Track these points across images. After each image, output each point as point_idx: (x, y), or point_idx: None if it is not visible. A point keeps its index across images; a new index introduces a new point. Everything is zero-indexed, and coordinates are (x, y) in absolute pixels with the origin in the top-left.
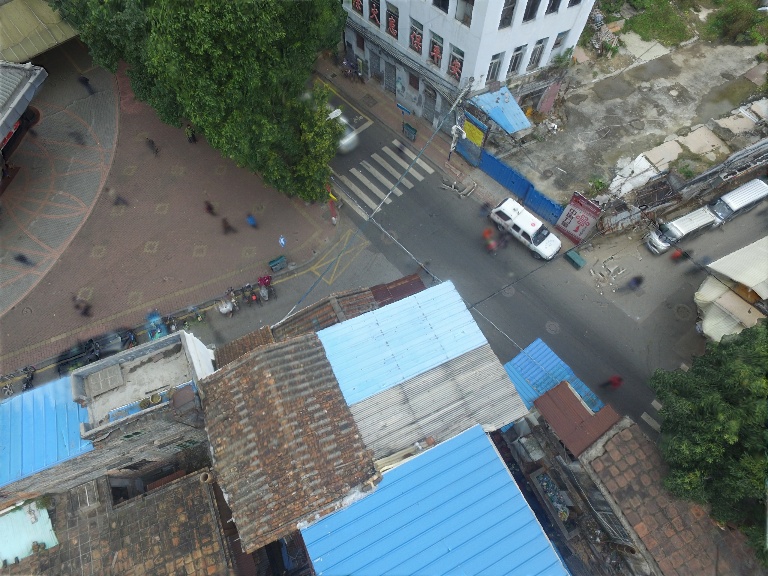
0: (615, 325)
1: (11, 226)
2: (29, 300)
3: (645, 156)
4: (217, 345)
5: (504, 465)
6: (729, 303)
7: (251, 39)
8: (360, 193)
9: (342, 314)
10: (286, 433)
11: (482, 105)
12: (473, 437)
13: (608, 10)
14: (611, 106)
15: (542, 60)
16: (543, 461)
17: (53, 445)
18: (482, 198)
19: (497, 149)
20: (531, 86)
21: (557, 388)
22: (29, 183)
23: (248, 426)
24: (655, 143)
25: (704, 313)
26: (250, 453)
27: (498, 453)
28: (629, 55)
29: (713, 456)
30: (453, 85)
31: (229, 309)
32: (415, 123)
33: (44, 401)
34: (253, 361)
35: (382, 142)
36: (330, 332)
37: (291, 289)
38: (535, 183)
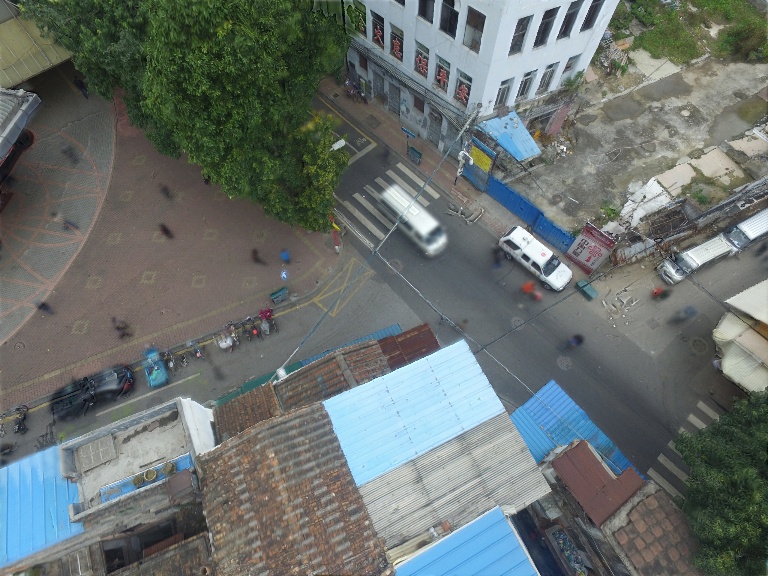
0: (629, 360)
1: (4, 255)
2: (22, 334)
3: (657, 180)
4: (217, 382)
5: (526, 554)
6: (750, 342)
7: (251, 79)
8: (364, 219)
9: (349, 372)
10: (291, 522)
11: (490, 131)
12: (492, 522)
13: (617, 27)
14: (621, 127)
15: (552, 84)
16: (560, 520)
17: (40, 526)
18: (490, 224)
19: (505, 173)
20: (540, 110)
21: (576, 448)
22: (22, 210)
23: (250, 512)
24: (667, 166)
25: (723, 351)
26: (252, 543)
27: (519, 539)
28: (639, 73)
29: (748, 535)
30: (460, 110)
31: (229, 344)
32: (420, 145)
33: (31, 474)
34: (255, 438)
35: (386, 165)
36: (337, 401)
37: (293, 322)
38: (544, 209)
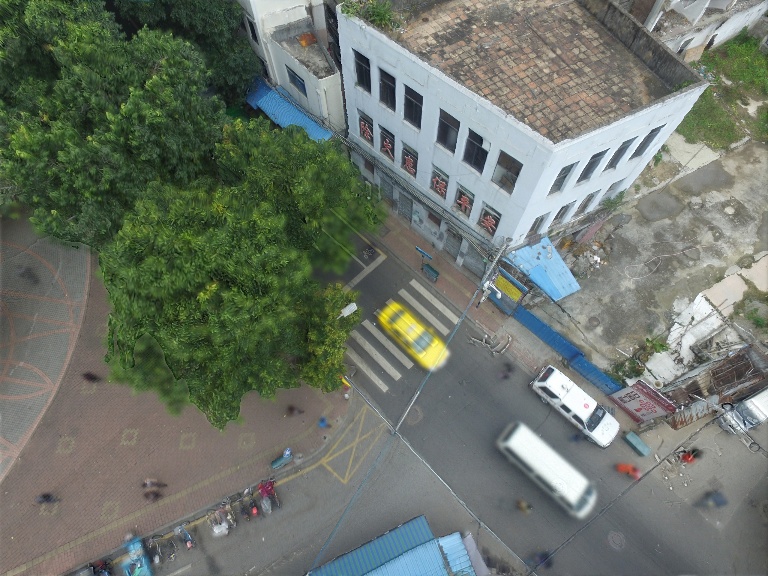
0: (691, 534)
1: None
2: None
3: (705, 296)
4: None
5: None
6: None
7: None
8: (376, 354)
9: None
10: None
11: (521, 264)
12: None
13: None
14: (659, 229)
15: (590, 207)
16: None
17: None
18: (519, 357)
19: (533, 291)
20: None
21: None
22: None
23: None
24: (715, 278)
25: None
26: None
27: None
28: (674, 162)
29: None
30: (485, 238)
31: (224, 526)
32: (435, 258)
33: None
34: None
35: (398, 283)
36: None
37: (299, 491)
38: (580, 335)
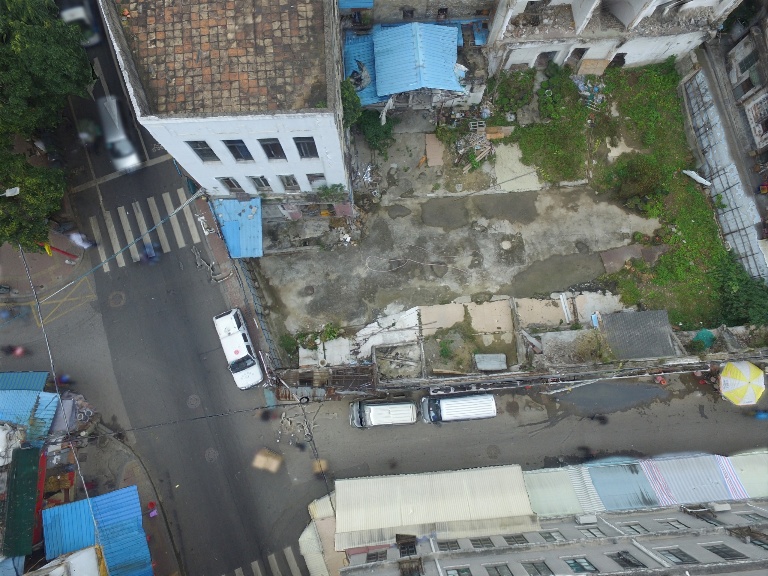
0: (270, 477)
1: None
2: None
3: (419, 311)
4: None
5: None
6: (325, 529)
7: None
8: (114, 239)
9: None
10: None
11: (221, 213)
12: None
13: (502, 107)
14: (427, 235)
15: (302, 187)
16: None
17: None
18: (229, 292)
19: (273, 242)
20: (298, 203)
21: None
22: None
23: None
24: (442, 299)
25: None
26: None
27: None
28: (491, 176)
29: None
30: None
31: None
32: None
33: None
34: None
35: (167, 186)
36: None
37: (3, 317)
38: (290, 296)
